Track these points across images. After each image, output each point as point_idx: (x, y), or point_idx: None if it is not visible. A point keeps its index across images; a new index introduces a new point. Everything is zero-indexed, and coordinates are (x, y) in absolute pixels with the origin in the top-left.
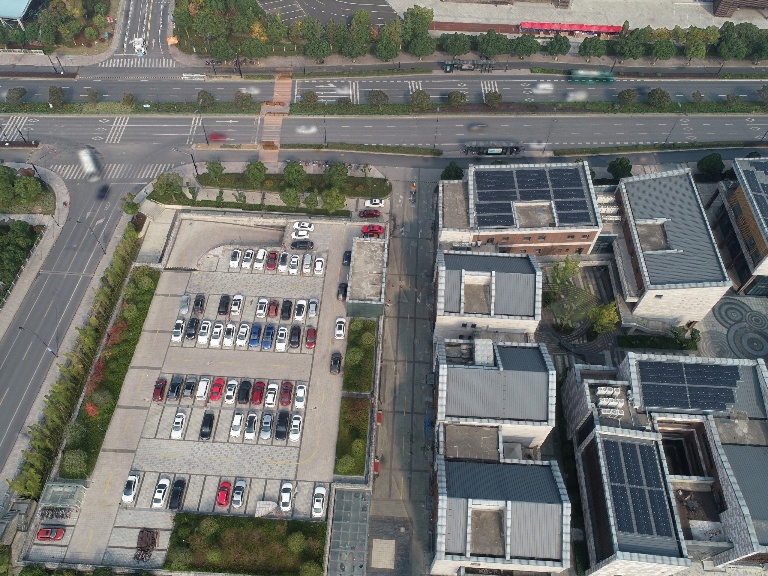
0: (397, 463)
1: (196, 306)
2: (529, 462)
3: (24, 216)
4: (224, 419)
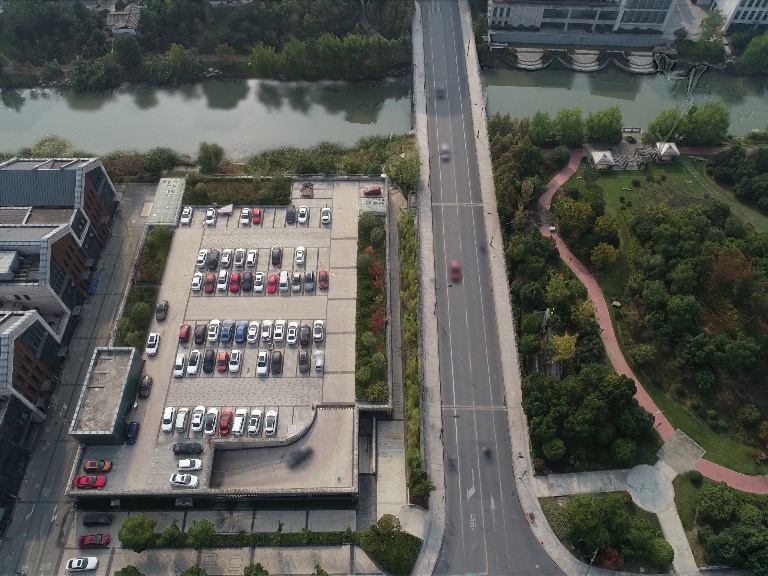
0: (128, 259)
1: (304, 354)
2: (10, 208)
3: (575, 490)
4: (264, 264)
